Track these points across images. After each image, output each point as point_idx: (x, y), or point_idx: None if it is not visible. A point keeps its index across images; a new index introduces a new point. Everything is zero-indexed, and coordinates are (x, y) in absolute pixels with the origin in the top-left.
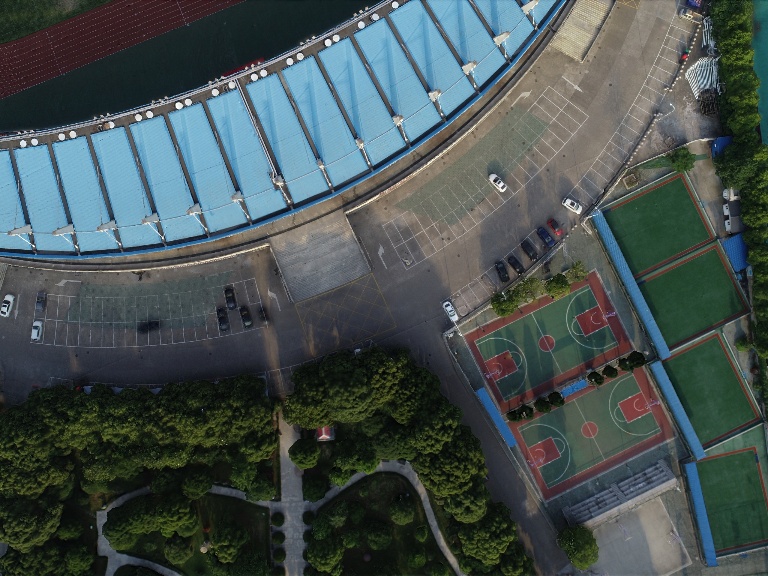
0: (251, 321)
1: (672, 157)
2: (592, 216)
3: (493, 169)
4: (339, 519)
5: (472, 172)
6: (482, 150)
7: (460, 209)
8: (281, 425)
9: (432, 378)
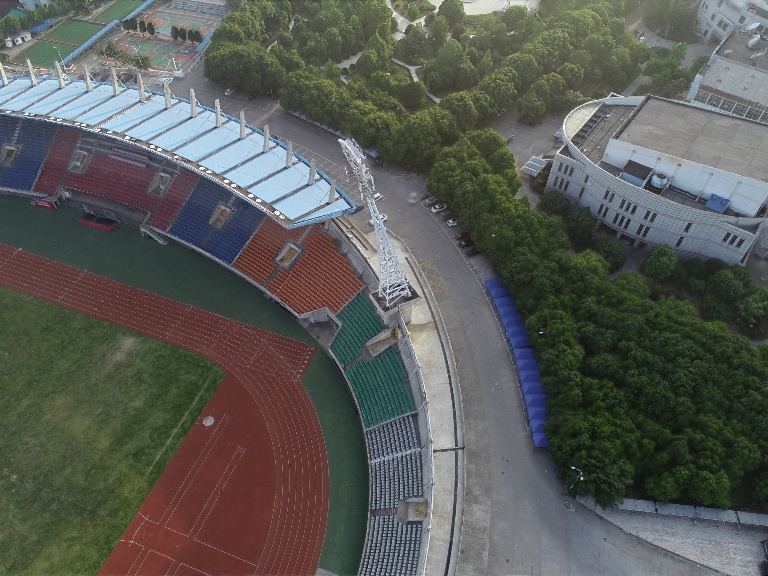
0: None
1: (2, 59)
2: None
3: None
4: None
5: None
6: None
7: None
8: None
9: None
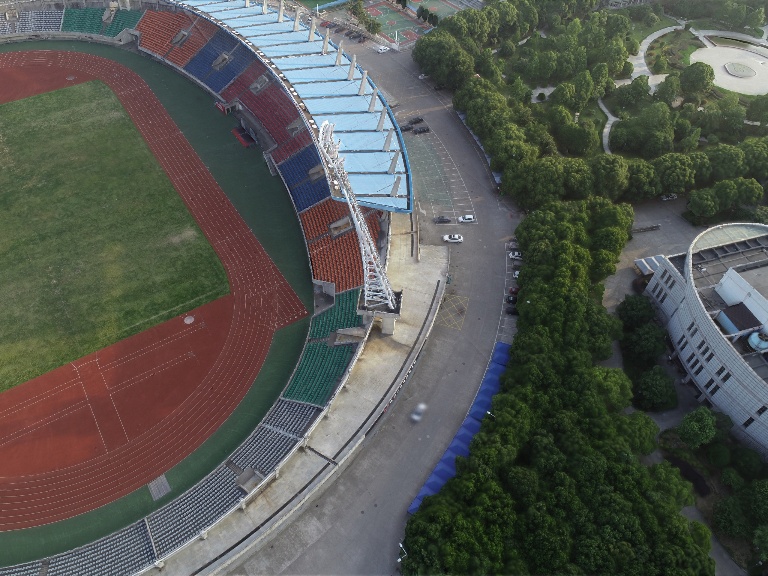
0: None
1: None
2: (317, 9)
3: None
4: None
5: None
6: None
7: None
8: None
9: None
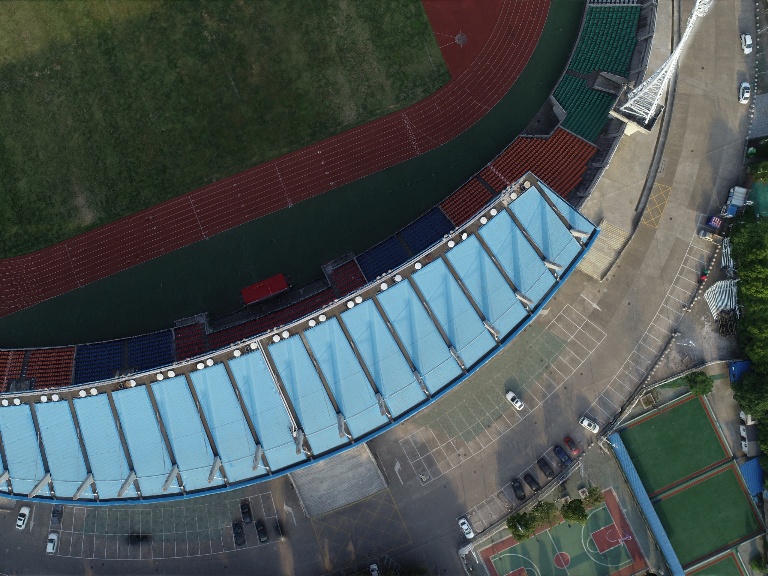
0: (267, 536)
1: (690, 382)
2: (609, 439)
3: (510, 386)
4: None
5: (489, 389)
6: (500, 367)
7: (477, 426)
8: None
9: None
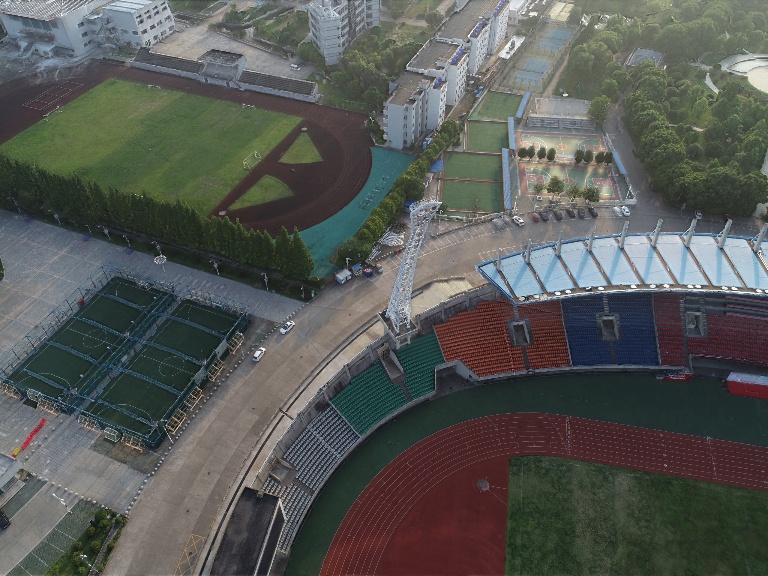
0: None
1: None
2: None
3: None
4: (740, 153)
5: None
6: None
7: None
8: (765, 211)
9: (659, 177)
